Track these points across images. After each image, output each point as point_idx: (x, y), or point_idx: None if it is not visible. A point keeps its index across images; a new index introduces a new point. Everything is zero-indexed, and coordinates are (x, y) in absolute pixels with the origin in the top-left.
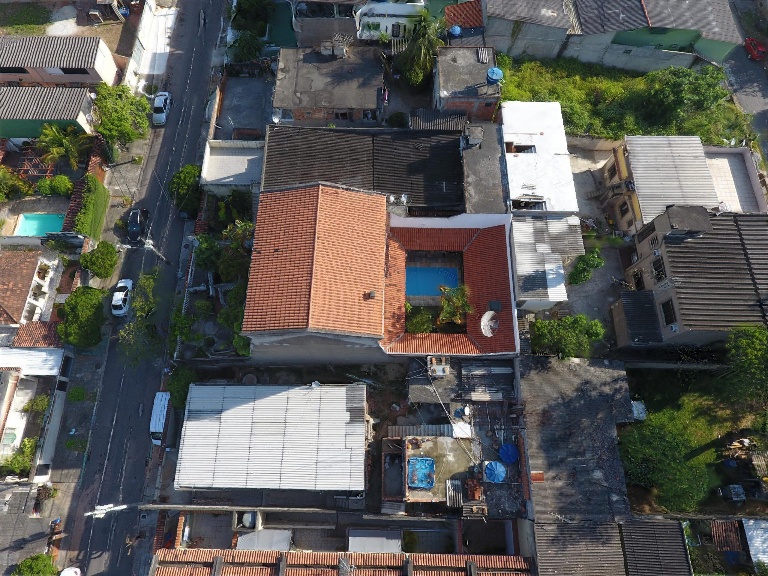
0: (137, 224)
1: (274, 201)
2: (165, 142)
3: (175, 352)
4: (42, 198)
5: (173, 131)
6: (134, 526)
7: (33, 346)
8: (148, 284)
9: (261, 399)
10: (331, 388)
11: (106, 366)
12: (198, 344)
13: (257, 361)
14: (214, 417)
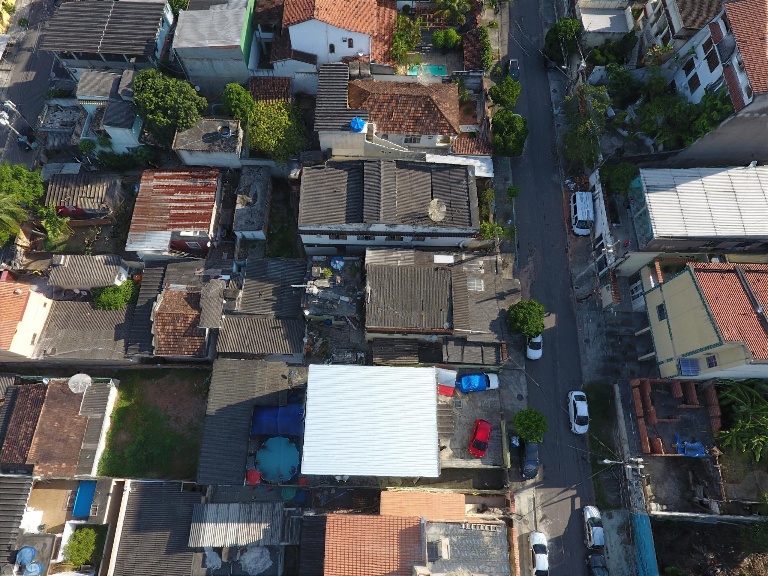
0: (517, 70)
1: (743, 7)
2: (512, 12)
3: (601, 155)
4: (420, 53)
5: (516, 3)
6: (570, 295)
7: (472, 154)
8: (602, 89)
9: (706, 176)
10: (764, 168)
11: (513, 179)
12: (611, 152)
13: (678, 158)
14: (670, 190)
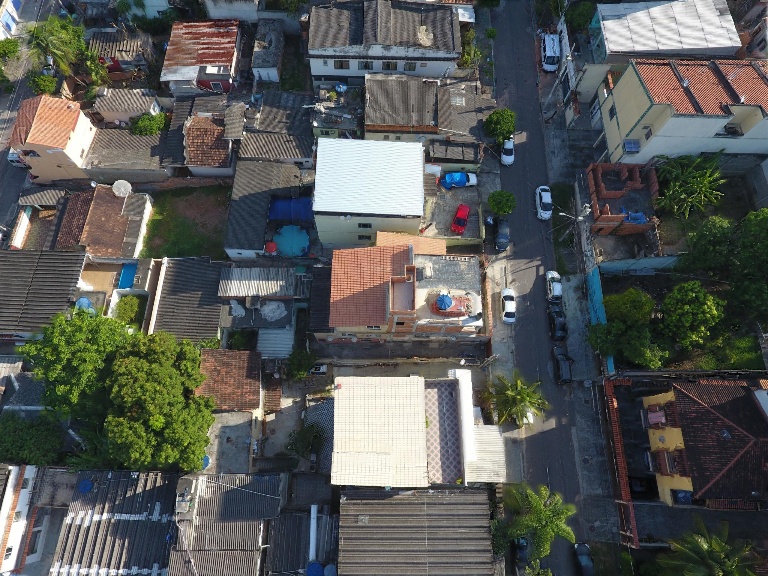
0: None
1: None
2: None
3: None
4: None
5: None
6: (539, 118)
7: (456, 3)
8: None
9: (652, 8)
10: None
11: None
12: None
13: None
14: (622, 18)
